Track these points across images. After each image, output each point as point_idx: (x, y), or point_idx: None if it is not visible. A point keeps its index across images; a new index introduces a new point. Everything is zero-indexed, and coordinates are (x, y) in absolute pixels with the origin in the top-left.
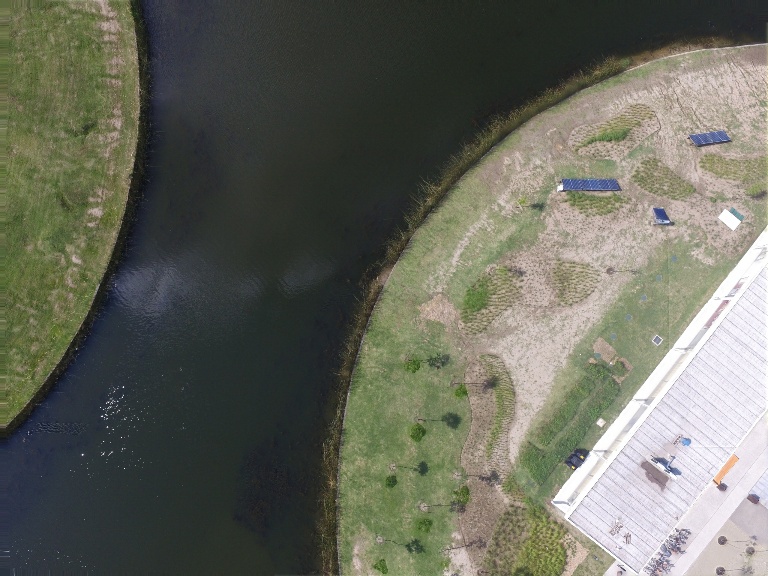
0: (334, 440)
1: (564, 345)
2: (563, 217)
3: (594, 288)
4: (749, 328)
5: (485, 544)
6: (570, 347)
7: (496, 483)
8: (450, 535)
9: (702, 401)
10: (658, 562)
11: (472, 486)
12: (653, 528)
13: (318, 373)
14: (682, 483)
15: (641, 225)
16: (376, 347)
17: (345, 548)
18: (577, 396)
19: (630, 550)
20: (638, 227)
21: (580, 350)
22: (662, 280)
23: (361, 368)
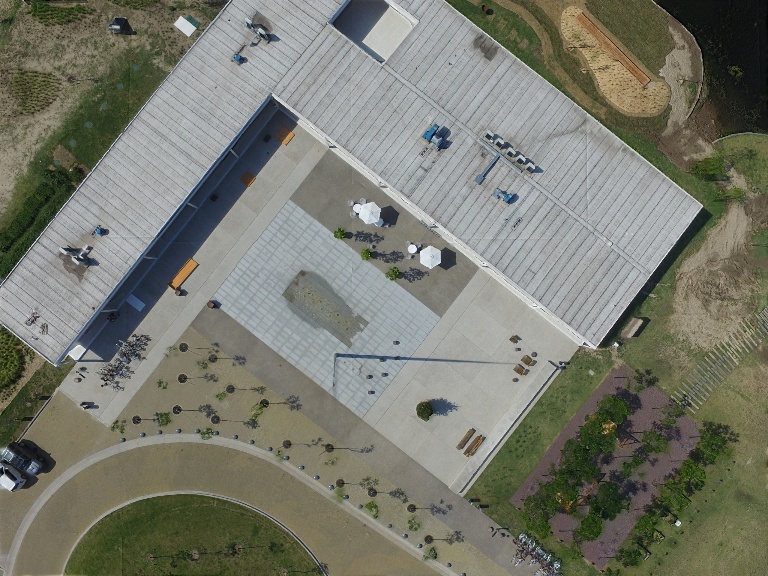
0: None
1: (25, 153)
2: (25, 27)
3: (56, 97)
4: (168, 119)
5: None
6: (31, 155)
7: None
8: None
9: (120, 192)
10: (117, 369)
11: None
12: (70, 319)
13: None
14: (100, 274)
15: (103, 35)
16: None
17: None
18: (34, 202)
19: (47, 341)
20: (100, 37)
21: (40, 157)
22: (123, 88)
23: None
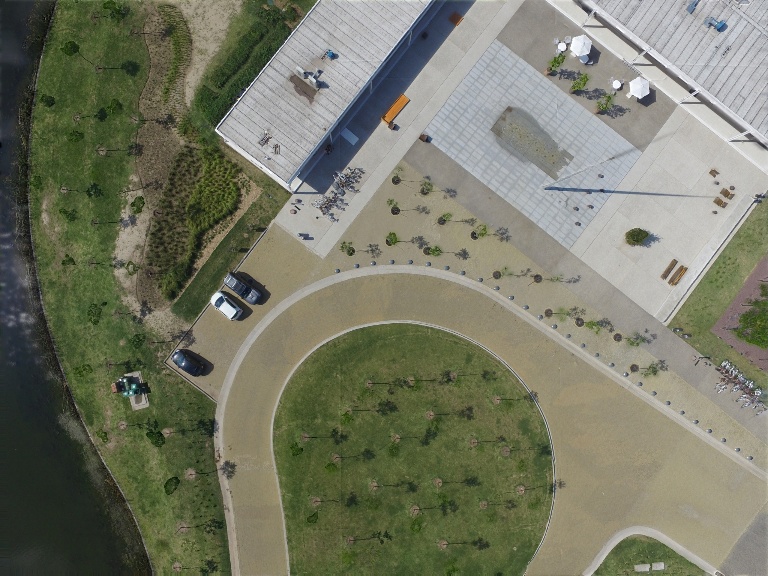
0: (28, 103)
1: None
2: None
3: None
4: None
5: (161, 185)
6: None
7: (172, 126)
8: (128, 178)
9: (349, 18)
10: (332, 201)
11: (149, 130)
12: (302, 140)
13: (16, 42)
14: (330, 96)
15: None
16: (67, 10)
17: (35, 205)
18: (249, 39)
19: (279, 161)
20: None
21: None
22: None
23: (54, 32)
